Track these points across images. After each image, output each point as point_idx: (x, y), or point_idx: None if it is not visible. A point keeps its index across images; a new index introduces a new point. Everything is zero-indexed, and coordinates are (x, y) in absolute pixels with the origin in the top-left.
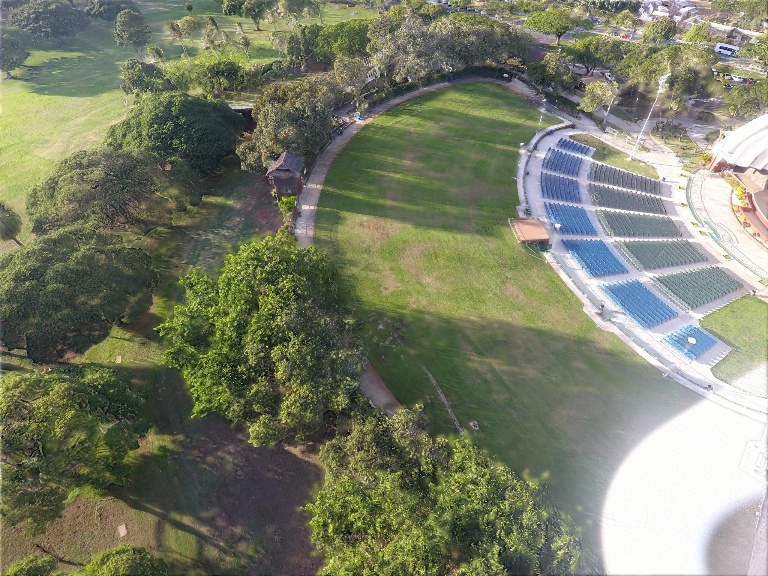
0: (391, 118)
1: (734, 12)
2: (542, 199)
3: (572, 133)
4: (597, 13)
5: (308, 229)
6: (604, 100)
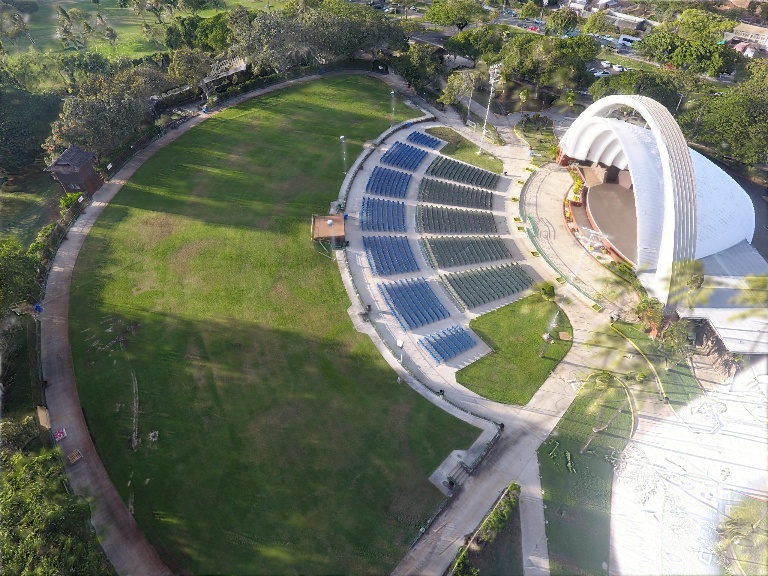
0: (239, 111)
1: (651, 4)
2: (365, 194)
3: (430, 126)
4: (515, 5)
5: (86, 227)
6: (459, 92)
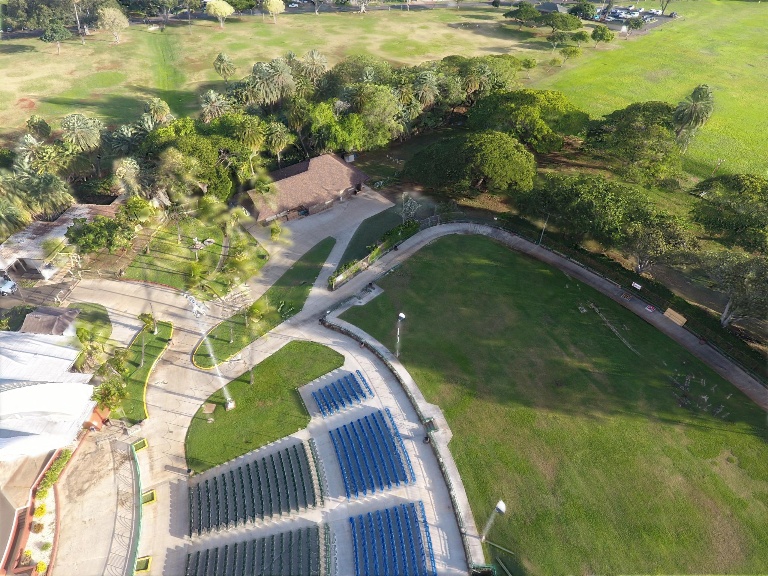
0: None
1: None
2: None
3: None
4: None
5: None
6: None
